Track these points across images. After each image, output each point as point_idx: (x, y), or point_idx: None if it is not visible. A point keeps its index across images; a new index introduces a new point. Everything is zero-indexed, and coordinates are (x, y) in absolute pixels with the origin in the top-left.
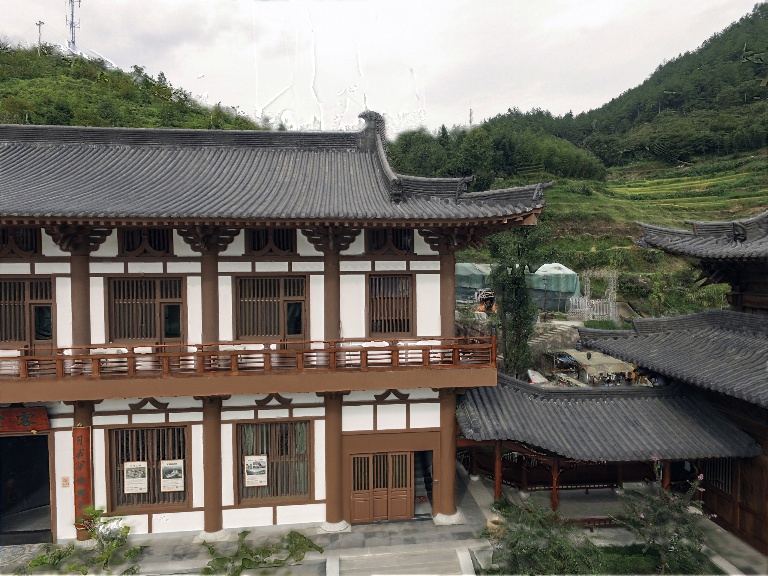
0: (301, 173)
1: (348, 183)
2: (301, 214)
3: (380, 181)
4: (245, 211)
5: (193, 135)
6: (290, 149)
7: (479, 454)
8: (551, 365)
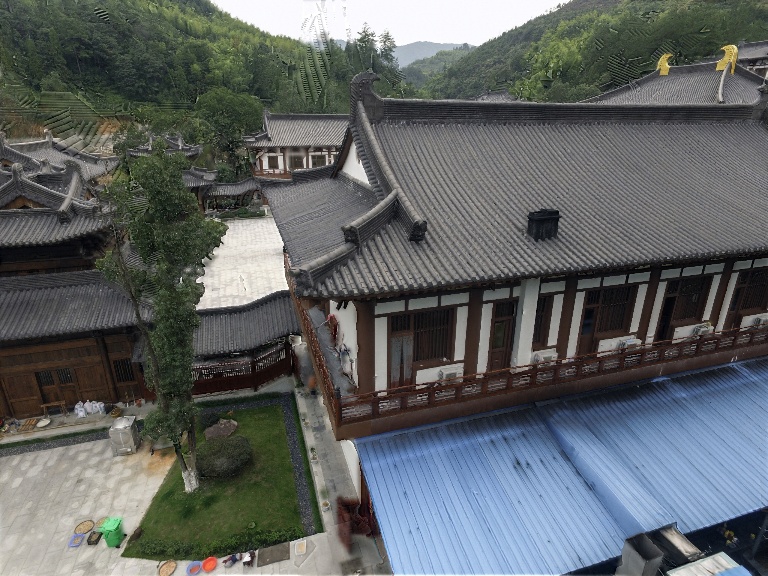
0: None
1: None
2: None
3: None
4: None
5: None
6: None
7: (284, 364)
8: None
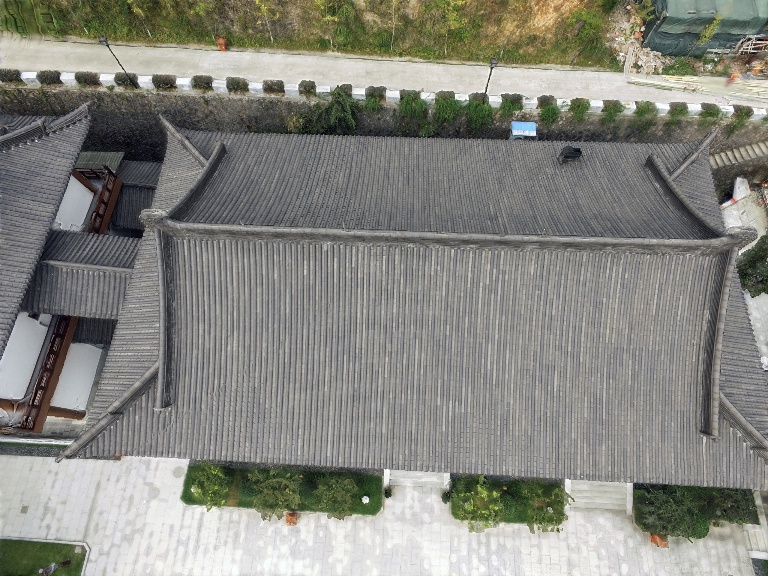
0: (628, 318)
1: (671, 354)
2: (634, 481)
3: (703, 348)
4: (596, 467)
5: (519, 243)
6: (621, 252)
7: None
8: (767, 174)
